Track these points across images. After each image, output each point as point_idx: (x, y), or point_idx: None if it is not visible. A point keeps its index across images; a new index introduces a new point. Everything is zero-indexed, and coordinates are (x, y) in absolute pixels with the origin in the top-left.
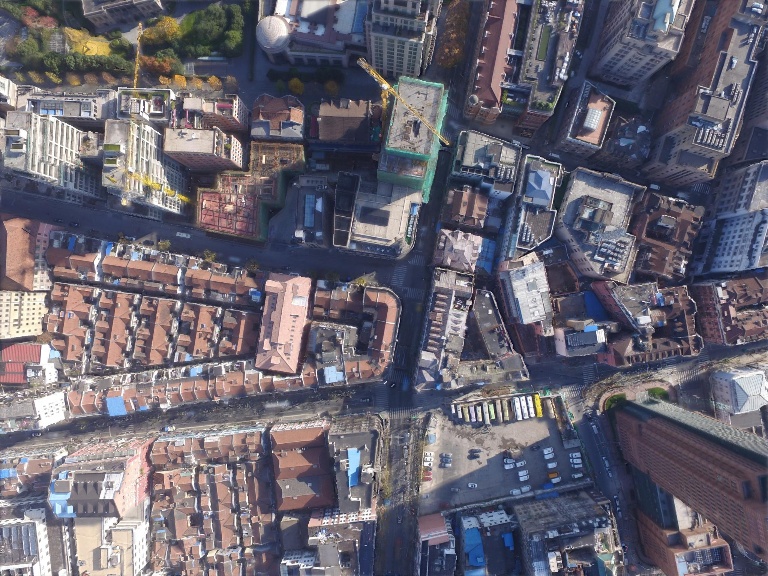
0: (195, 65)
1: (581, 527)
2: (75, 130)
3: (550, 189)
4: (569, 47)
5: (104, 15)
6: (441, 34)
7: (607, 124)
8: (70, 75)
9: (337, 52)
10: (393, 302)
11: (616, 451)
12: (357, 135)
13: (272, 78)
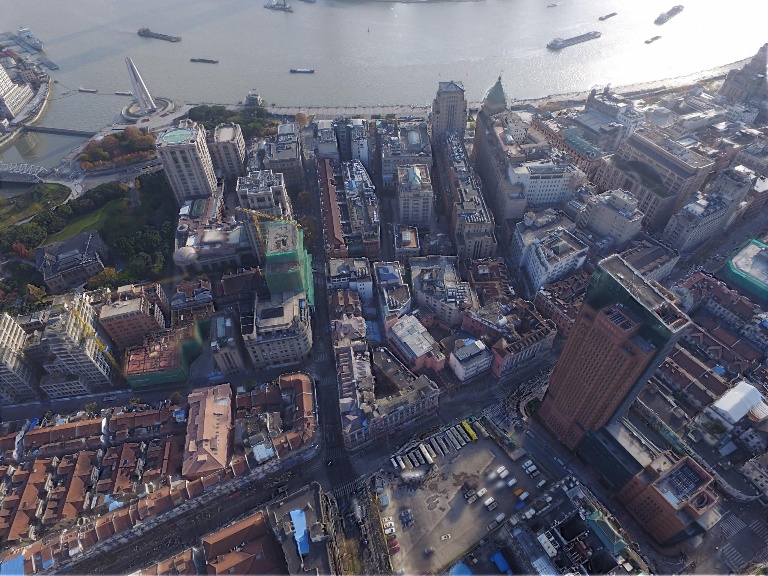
0: None
1: (552, 495)
2: (23, 332)
3: (396, 273)
4: (374, 210)
5: (59, 279)
6: None
7: (417, 237)
8: None
9: (231, 254)
10: (306, 378)
11: (561, 448)
12: (252, 285)
13: None
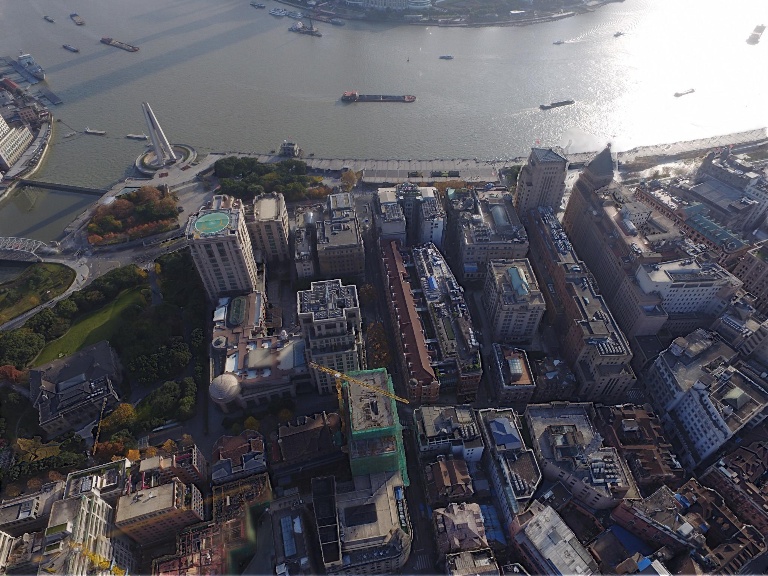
0: (149, 438)
1: None
2: (7, 537)
3: (515, 431)
4: (468, 325)
5: (60, 420)
6: (368, 348)
7: (528, 367)
8: (11, 486)
9: (285, 385)
10: None
11: None
12: (320, 445)
13: (227, 425)
